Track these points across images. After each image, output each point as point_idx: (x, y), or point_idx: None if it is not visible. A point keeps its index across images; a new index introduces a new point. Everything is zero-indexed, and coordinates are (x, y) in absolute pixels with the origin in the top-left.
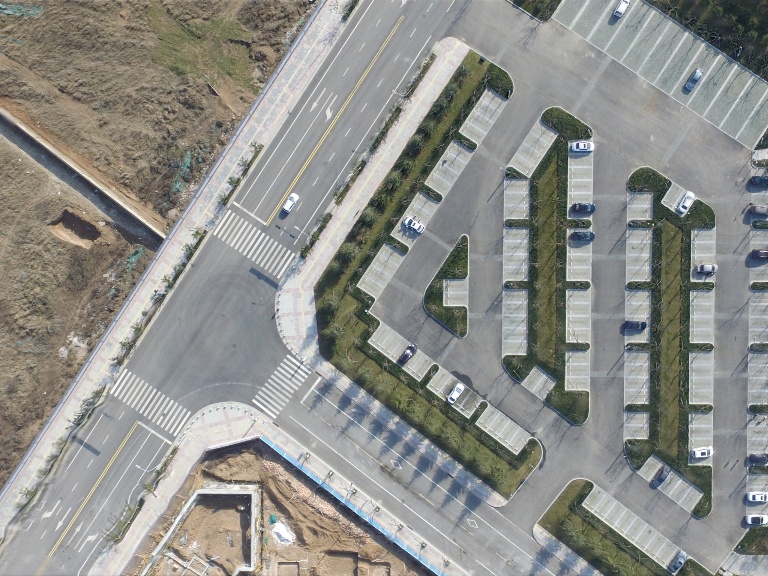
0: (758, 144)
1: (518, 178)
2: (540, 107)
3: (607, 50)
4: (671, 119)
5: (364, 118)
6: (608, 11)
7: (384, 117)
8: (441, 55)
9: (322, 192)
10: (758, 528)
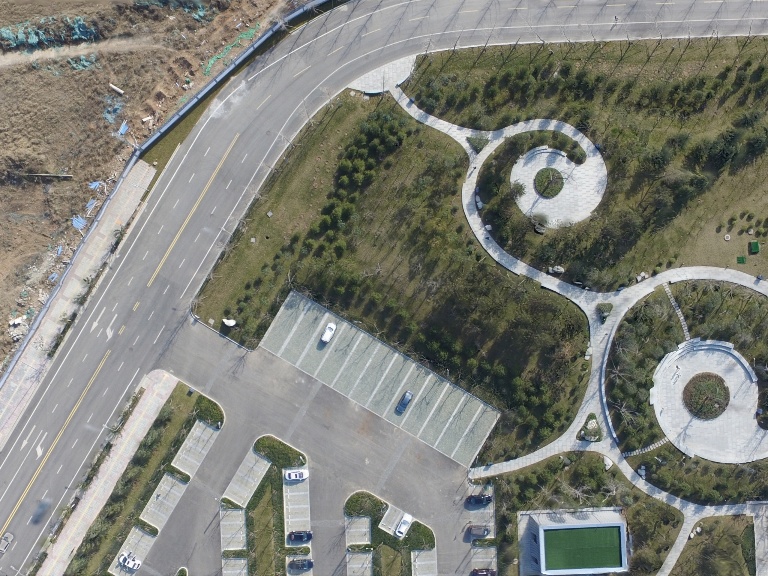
0: (473, 463)
1: (233, 508)
2: (252, 435)
3: (317, 375)
4: (385, 441)
5: (75, 454)
6: (316, 336)
7: (96, 452)
8: (149, 388)
9: (36, 531)
10: None
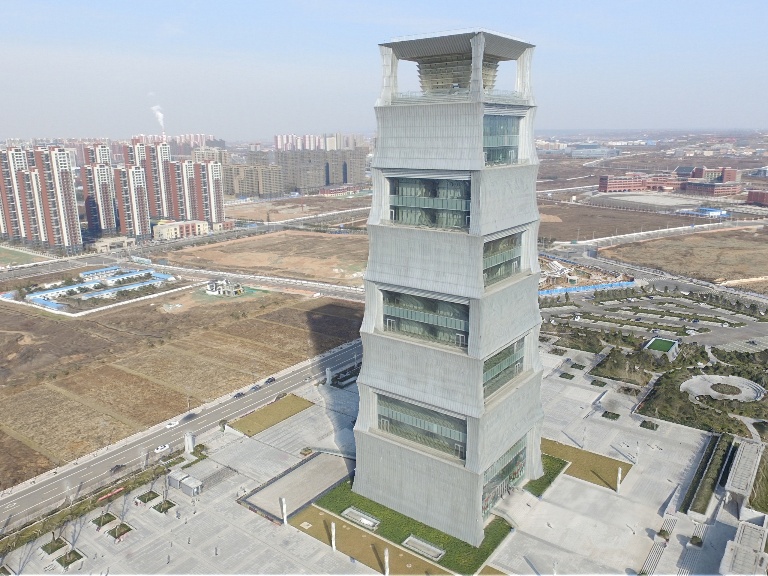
0: None
1: None
2: None
3: None
4: (734, 338)
5: None
6: None
7: None
8: None
9: None
10: None
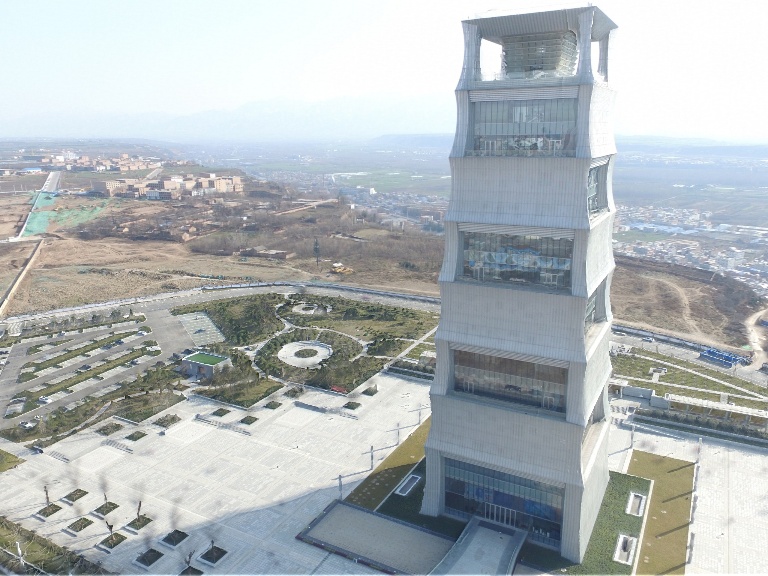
0: None
1: None
2: None
3: None
4: None
5: None
6: None
7: None
8: None
9: None
10: (20, 427)
